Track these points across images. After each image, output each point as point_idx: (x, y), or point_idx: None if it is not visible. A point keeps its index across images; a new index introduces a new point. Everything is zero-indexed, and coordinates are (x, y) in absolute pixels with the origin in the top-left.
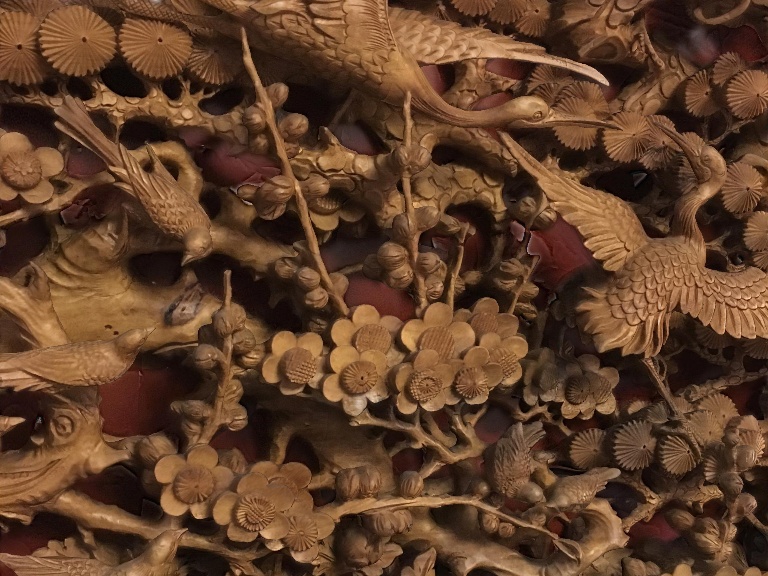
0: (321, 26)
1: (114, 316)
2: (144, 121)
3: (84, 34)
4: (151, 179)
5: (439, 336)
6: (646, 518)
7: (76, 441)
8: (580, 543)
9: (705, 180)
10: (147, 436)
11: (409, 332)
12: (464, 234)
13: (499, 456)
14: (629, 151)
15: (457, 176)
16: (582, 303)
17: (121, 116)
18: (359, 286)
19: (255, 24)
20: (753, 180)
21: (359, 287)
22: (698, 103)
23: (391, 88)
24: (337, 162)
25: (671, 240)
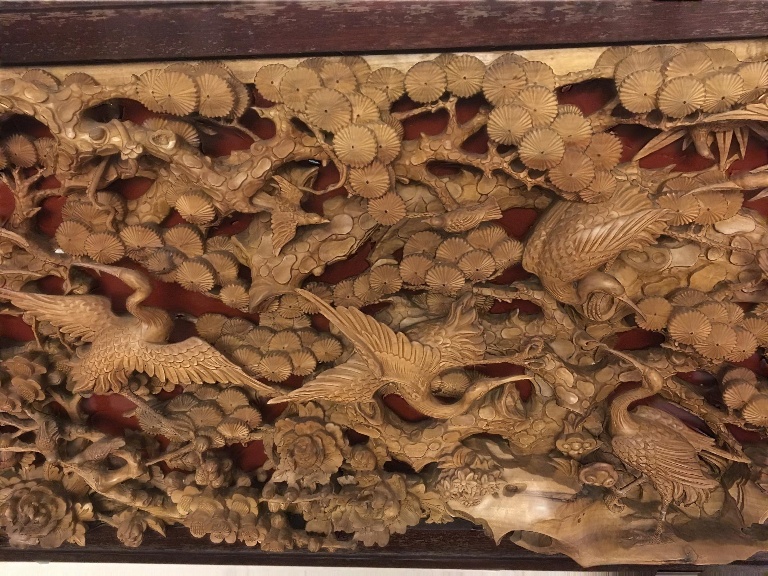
0: None
1: None
2: None
3: None
4: None
5: None
6: None
7: None
8: (113, 473)
9: None
10: None
11: None
12: None
13: (36, 437)
14: (106, 258)
15: (30, 264)
16: (68, 362)
17: None
18: (0, 323)
19: None
20: (198, 274)
21: (0, 323)
22: None
23: None
24: None
25: (127, 322)
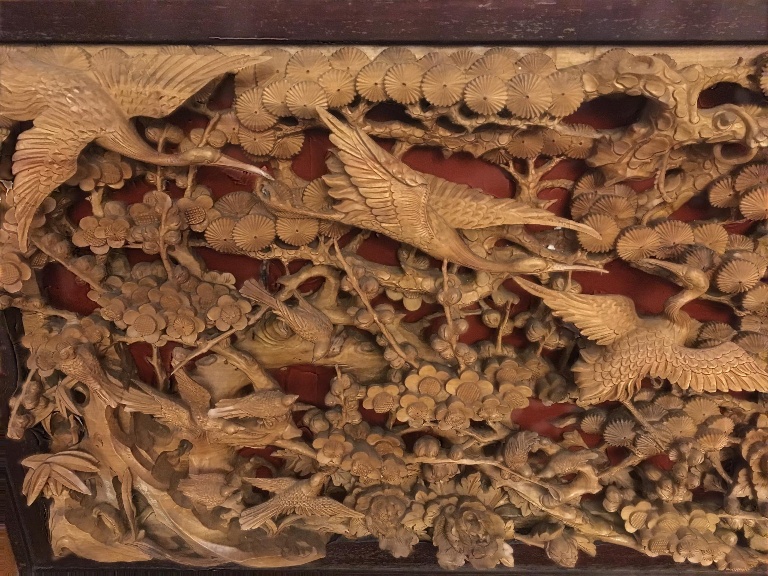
0: (385, 227)
1: (297, 354)
2: (300, 260)
3: (255, 234)
4: (294, 316)
5: (468, 389)
6: (633, 464)
7: (275, 428)
8: (567, 487)
9: (689, 289)
10: (315, 415)
11: (451, 384)
12: (509, 304)
13: (508, 448)
14: (638, 255)
15: None
16: (575, 367)
17: (286, 261)
18: None
19: (347, 224)
20: (748, 274)
21: None
22: (722, 201)
23: (435, 255)
24: (410, 285)
25: (656, 325)
